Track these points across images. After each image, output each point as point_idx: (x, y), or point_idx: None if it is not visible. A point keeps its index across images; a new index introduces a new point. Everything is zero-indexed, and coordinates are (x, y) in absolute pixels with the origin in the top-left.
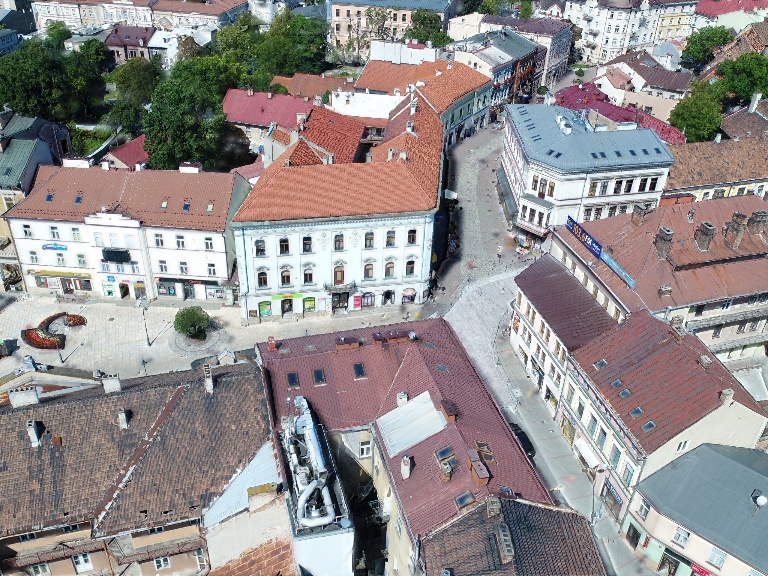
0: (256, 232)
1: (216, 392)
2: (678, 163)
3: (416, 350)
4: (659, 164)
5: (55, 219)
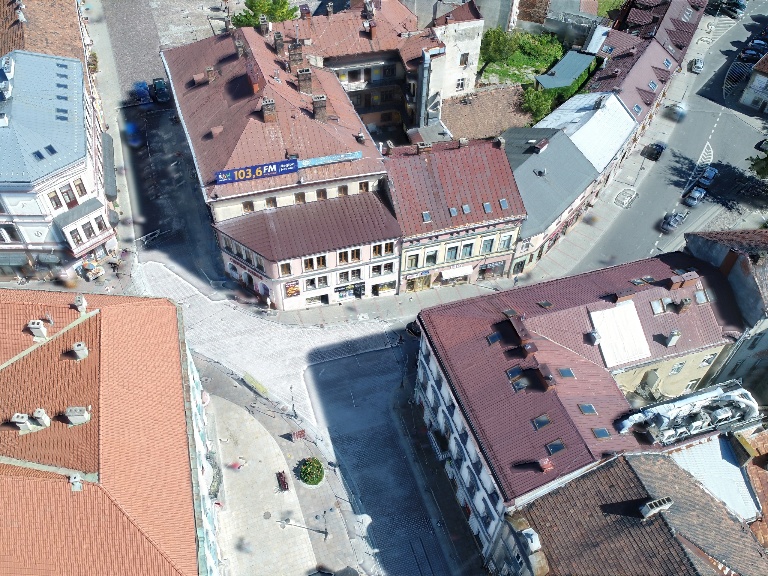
0: None
1: None
2: None
3: (534, 320)
4: None
5: None
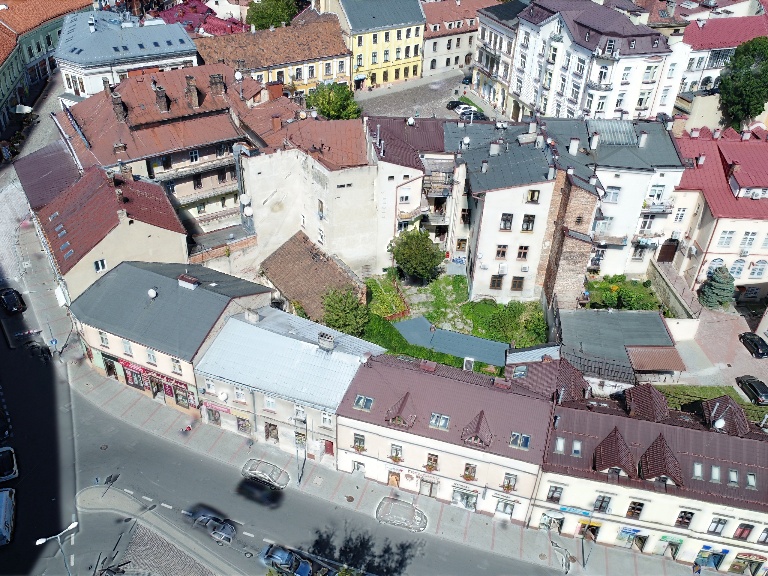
0: None
1: None
2: (213, 53)
3: None
4: (182, 53)
5: None
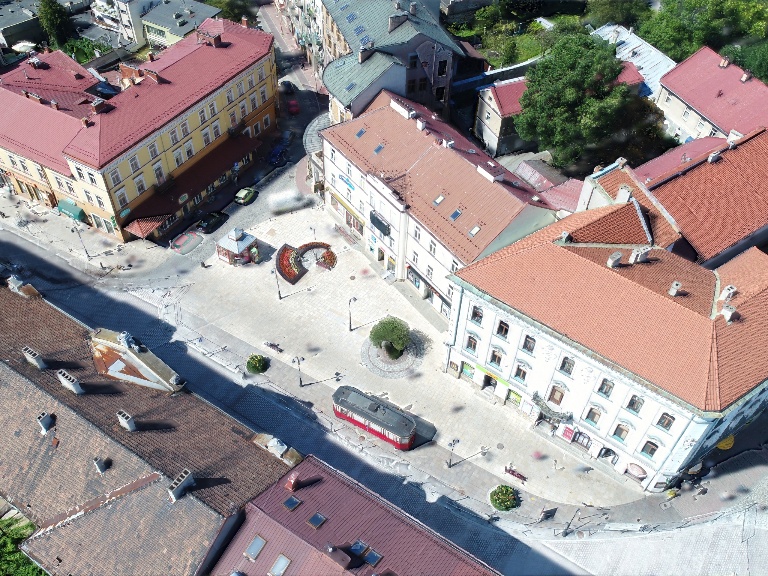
0: (476, 298)
1: (177, 504)
2: None
3: None
4: None
5: (350, 159)
